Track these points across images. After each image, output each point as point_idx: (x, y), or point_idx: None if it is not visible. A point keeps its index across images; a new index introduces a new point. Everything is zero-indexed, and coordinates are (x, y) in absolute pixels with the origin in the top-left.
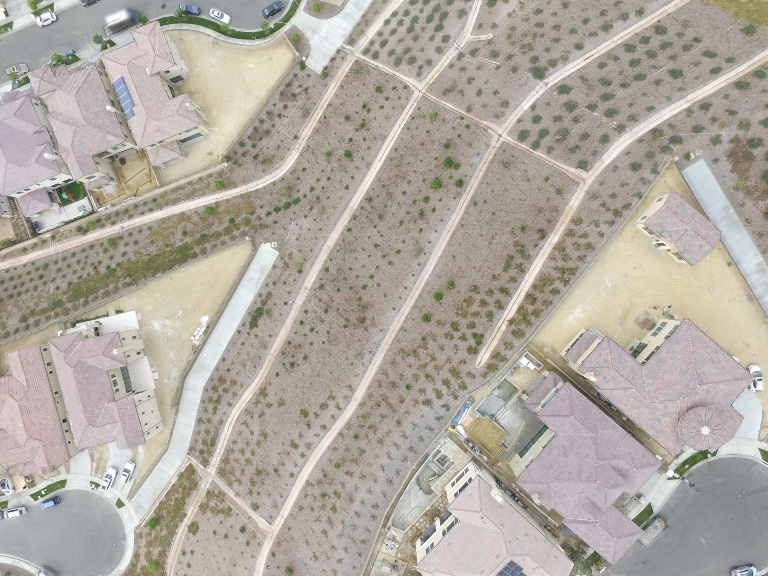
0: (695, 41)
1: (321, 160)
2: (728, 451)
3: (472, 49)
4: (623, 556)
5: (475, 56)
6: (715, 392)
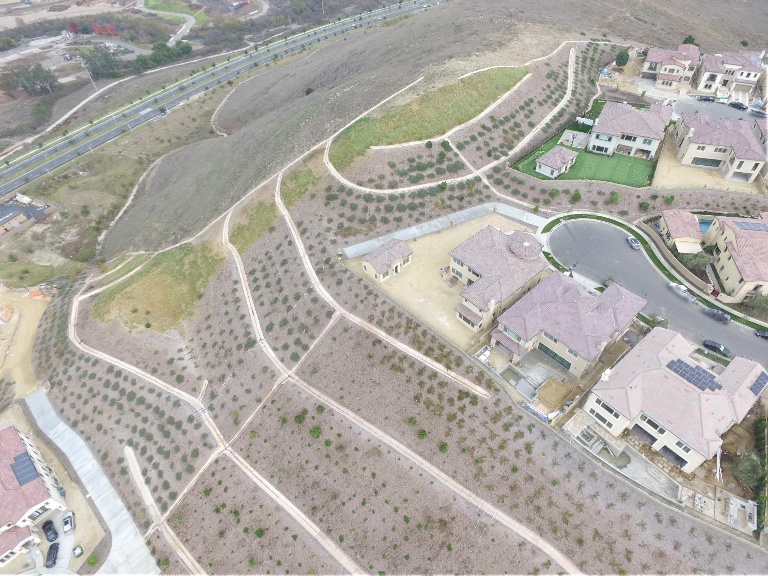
0: (267, 254)
1: (255, 574)
2: (545, 247)
3: (210, 397)
4: (645, 307)
5: (216, 395)
6: (500, 241)
